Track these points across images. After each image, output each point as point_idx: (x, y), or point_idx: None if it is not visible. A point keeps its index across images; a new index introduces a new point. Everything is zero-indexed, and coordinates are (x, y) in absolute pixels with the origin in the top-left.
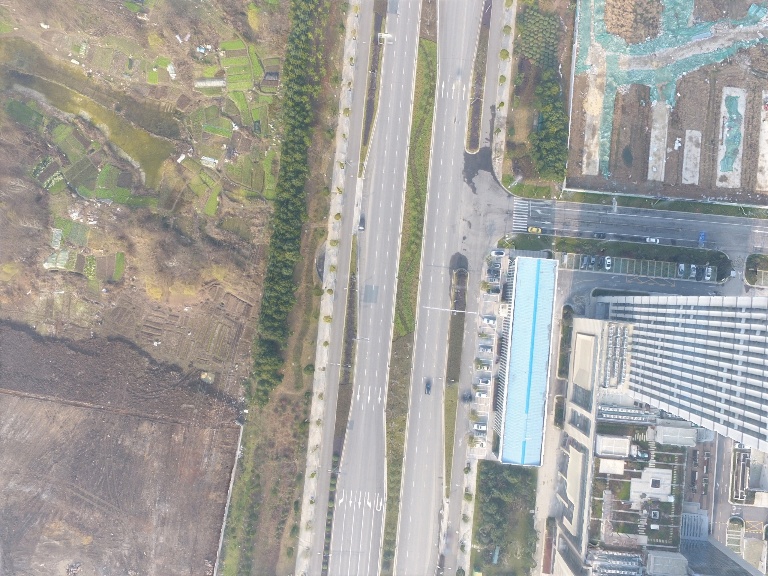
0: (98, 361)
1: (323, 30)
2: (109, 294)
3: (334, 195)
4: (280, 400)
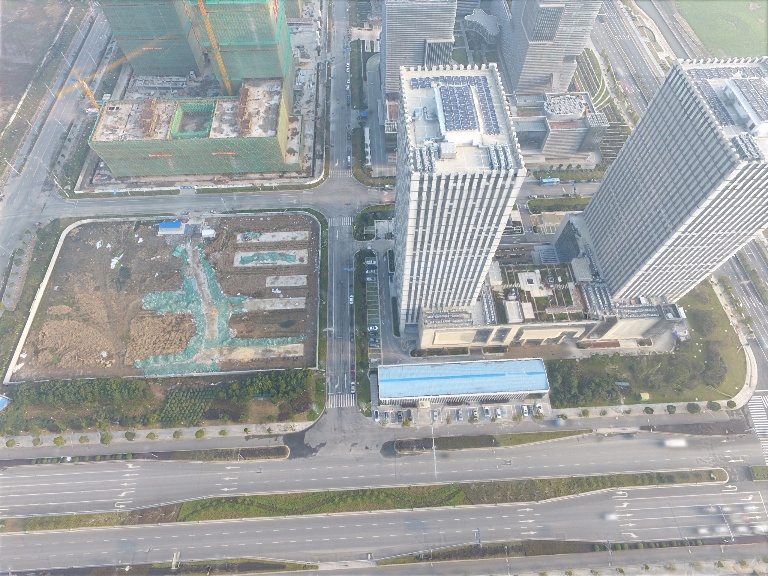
0: None
1: None
2: None
3: None
4: None
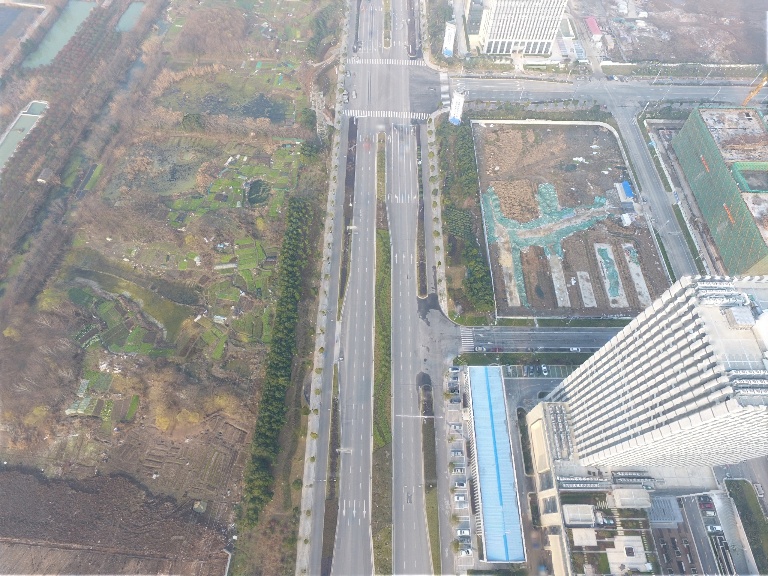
0: (96, 498)
1: (309, 228)
2: (119, 432)
3: (318, 335)
4: (269, 521)
